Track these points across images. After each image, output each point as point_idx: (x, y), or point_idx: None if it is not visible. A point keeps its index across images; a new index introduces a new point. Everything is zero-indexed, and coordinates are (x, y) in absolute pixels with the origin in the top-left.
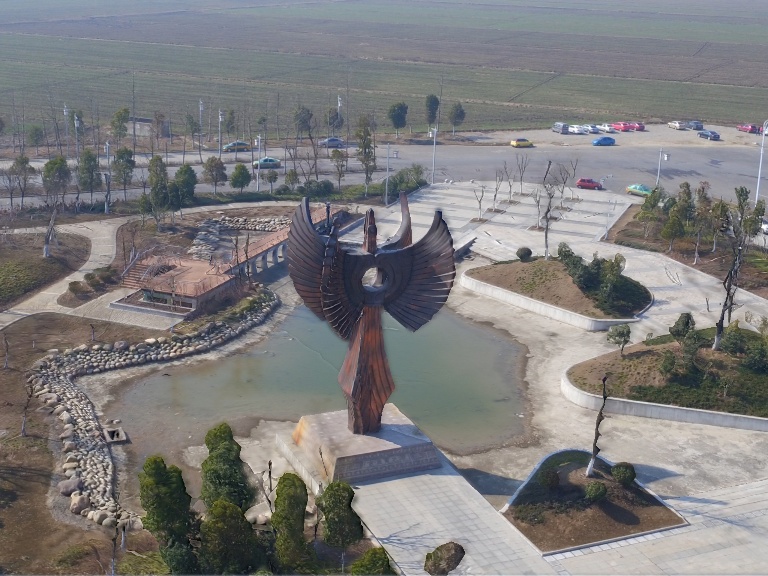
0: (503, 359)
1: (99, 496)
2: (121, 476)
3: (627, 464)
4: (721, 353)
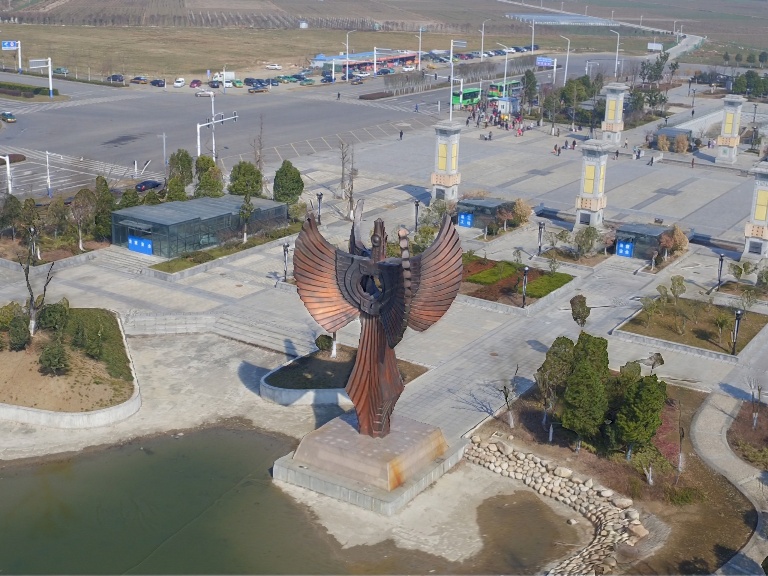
0: (19, 473)
1: (609, 539)
2: (553, 566)
3: (325, 335)
4: (39, 333)
